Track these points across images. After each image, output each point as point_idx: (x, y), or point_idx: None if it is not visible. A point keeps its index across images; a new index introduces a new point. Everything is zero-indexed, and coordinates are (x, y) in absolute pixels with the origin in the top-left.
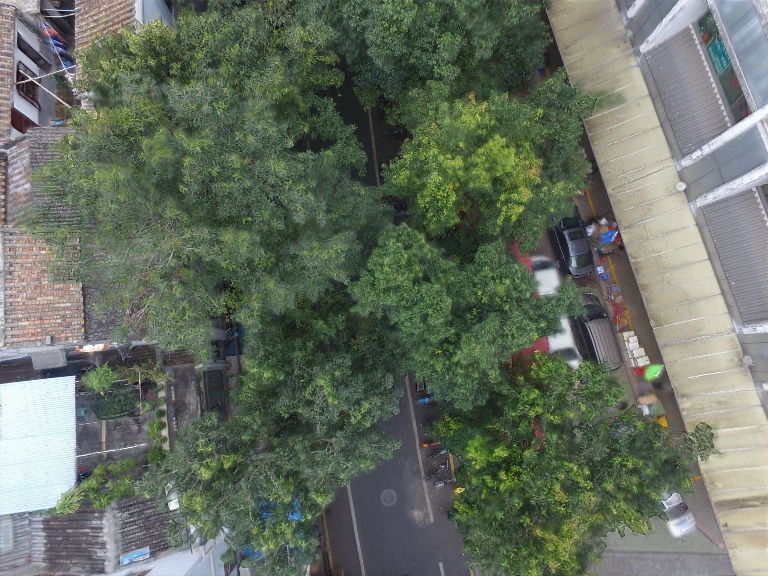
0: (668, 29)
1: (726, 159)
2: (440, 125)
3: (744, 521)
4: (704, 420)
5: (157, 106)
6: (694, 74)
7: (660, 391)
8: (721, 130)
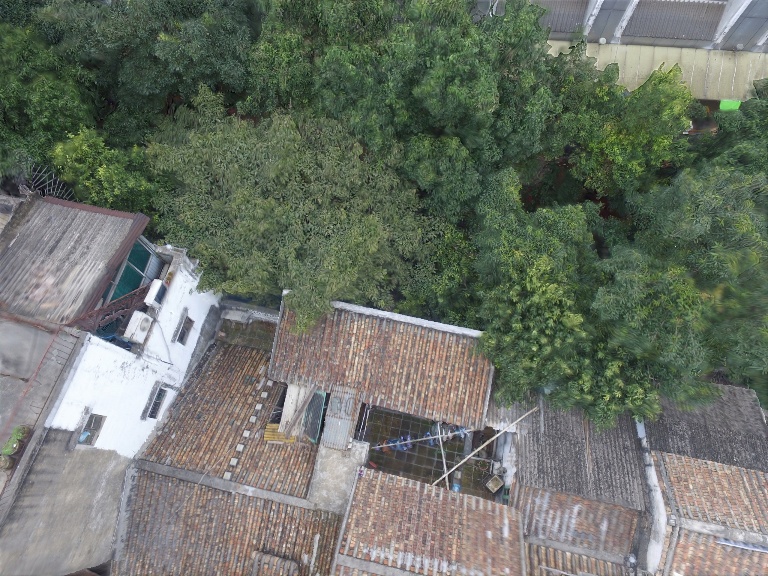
0: (497, 2)
1: (614, 1)
2: (601, 128)
3: None
4: None
5: (643, 277)
6: (531, 2)
7: (705, 127)
8: (580, 1)
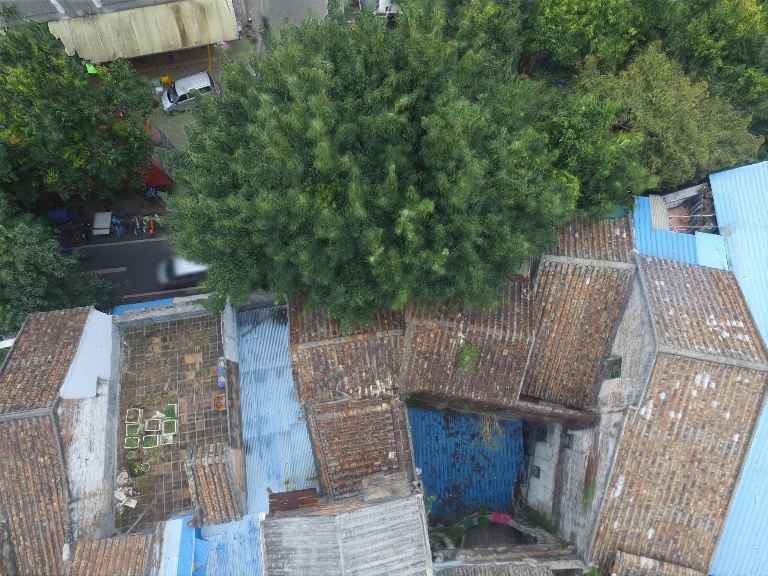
0: None
1: None
2: None
3: (193, 32)
4: (131, 46)
5: None
6: None
7: None
8: None
